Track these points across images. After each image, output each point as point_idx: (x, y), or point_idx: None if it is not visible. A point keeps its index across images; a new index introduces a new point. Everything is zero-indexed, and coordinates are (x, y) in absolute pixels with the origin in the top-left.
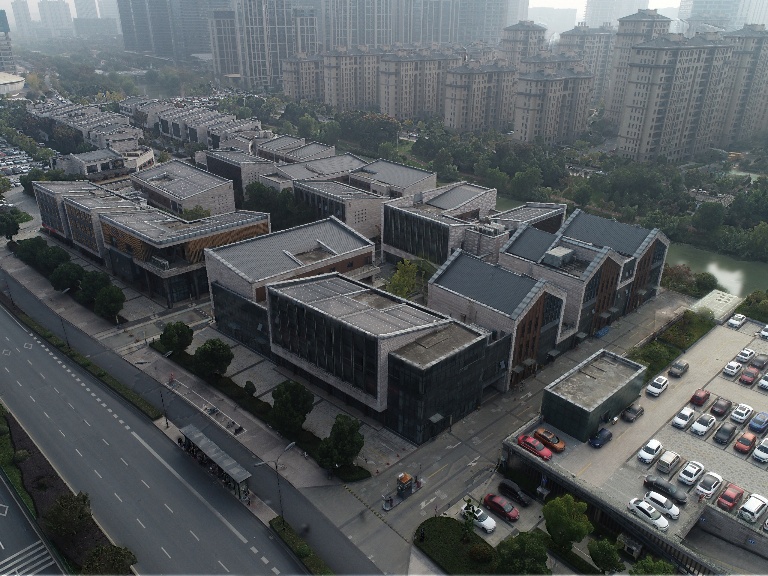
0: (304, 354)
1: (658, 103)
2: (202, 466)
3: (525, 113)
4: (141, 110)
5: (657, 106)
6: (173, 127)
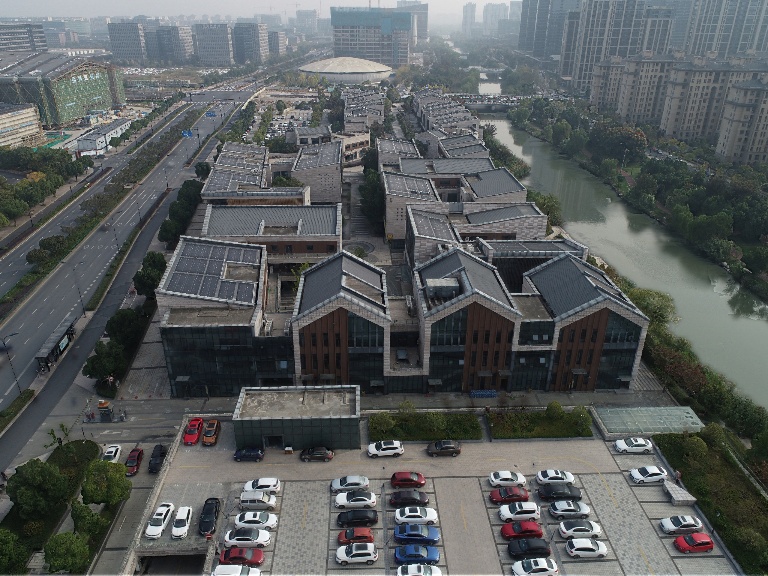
0: None
1: None
2: None
3: None
4: (418, 101)
5: None
6: (424, 118)
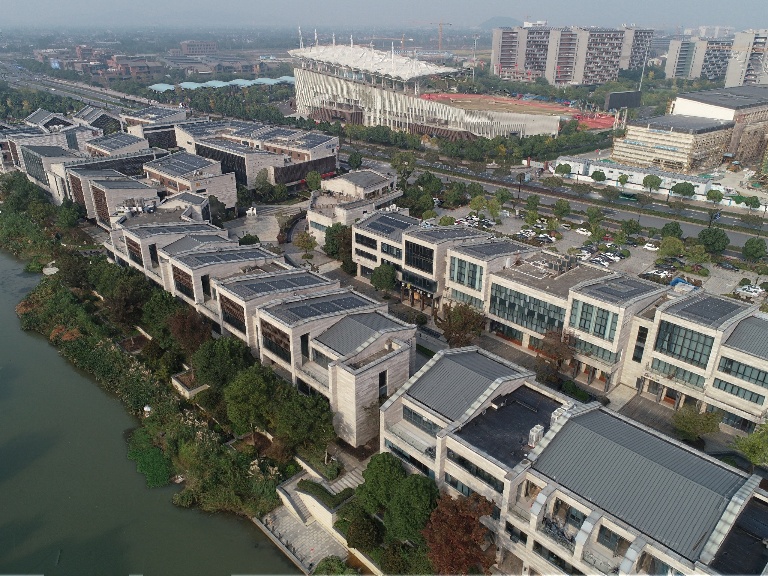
0: None
1: None
2: None
3: None
4: (509, 365)
5: None
6: None
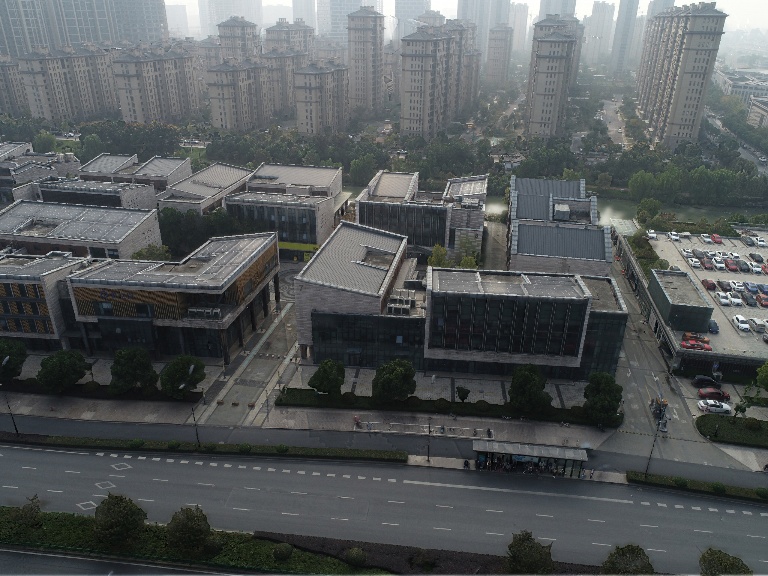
0: (475, 346)
1: (430, 87)
2: (512, 472)
3: (308, 106)
4: None
5: (430, 89)
6: None
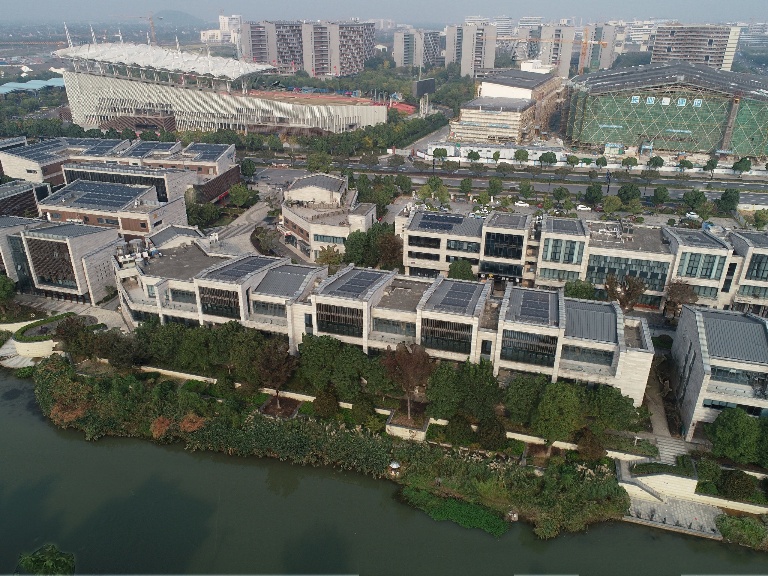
0: None
1: None
2: None
3: None
4: (720, 313)
5: None
6: None
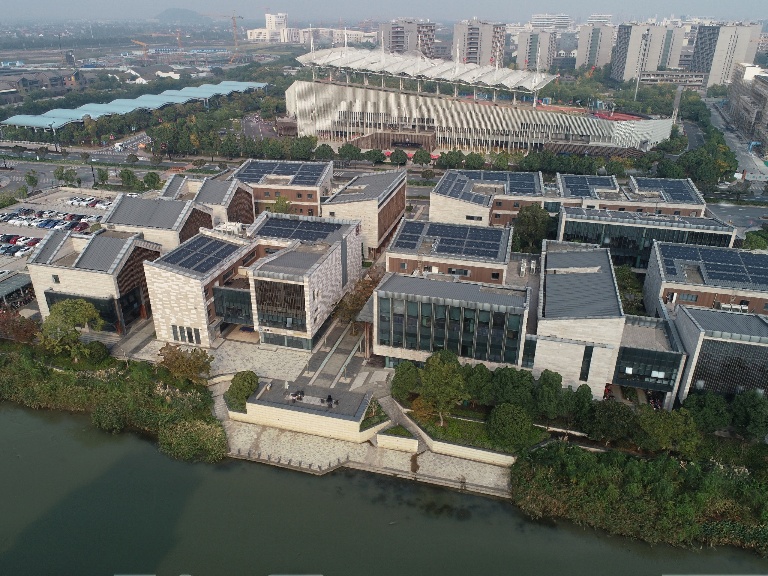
0: None
1: None
2: None
3: None
4: None
5: None
6: None
